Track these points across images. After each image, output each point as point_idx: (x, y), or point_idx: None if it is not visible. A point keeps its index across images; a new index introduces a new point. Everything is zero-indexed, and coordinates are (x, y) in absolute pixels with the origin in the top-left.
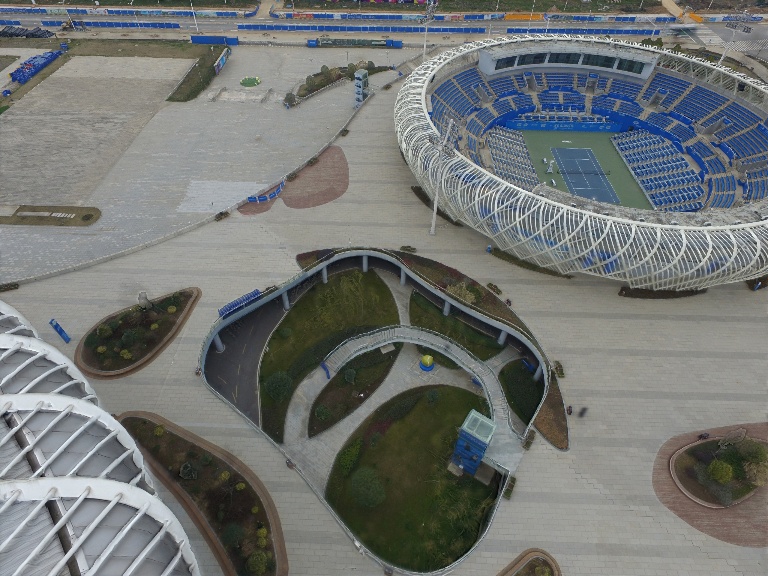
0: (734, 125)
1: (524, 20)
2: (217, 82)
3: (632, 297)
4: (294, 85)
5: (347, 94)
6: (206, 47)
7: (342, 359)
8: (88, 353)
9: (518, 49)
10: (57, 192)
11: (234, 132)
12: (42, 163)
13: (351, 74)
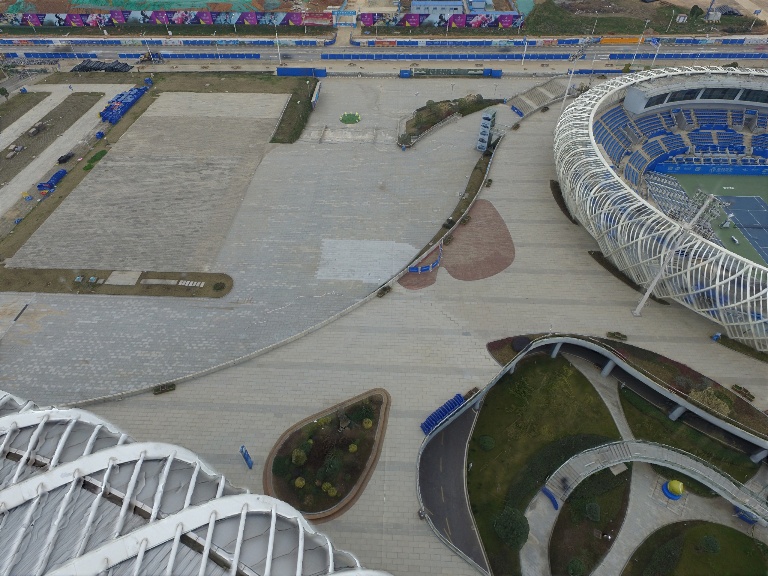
0: None
1: (621, 44)
2: (315, 119)
3: None
4: (399, 122)
5: (462, 132)
6: (296, 80)
7: (568, 483)
8: (282, 486)
9: (671, 85)
10: (179, 254)
11: (353, 179)
12: (155, 219)
13: (460, 109)
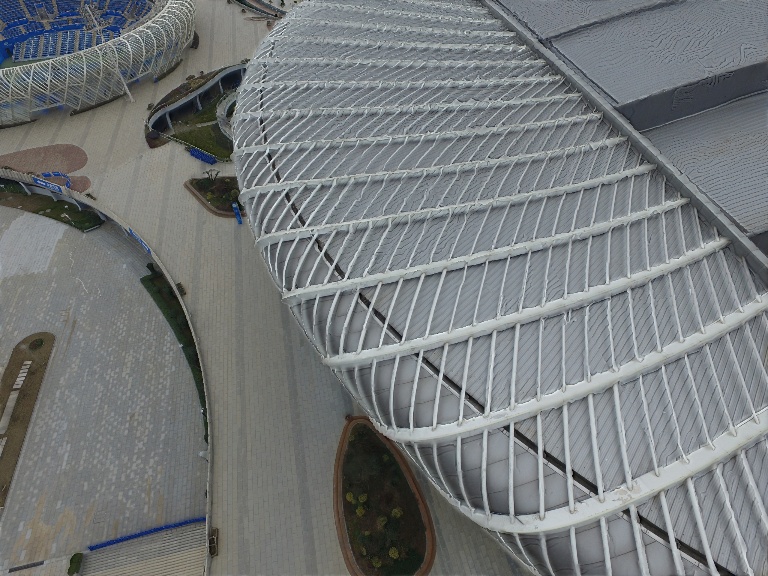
0: (45, 4)
1: None
2: None
3: (198, 46)
4: None
5: None
6: None
7: None
8: None
9: None
10: None
11: None
12: None
13: None
